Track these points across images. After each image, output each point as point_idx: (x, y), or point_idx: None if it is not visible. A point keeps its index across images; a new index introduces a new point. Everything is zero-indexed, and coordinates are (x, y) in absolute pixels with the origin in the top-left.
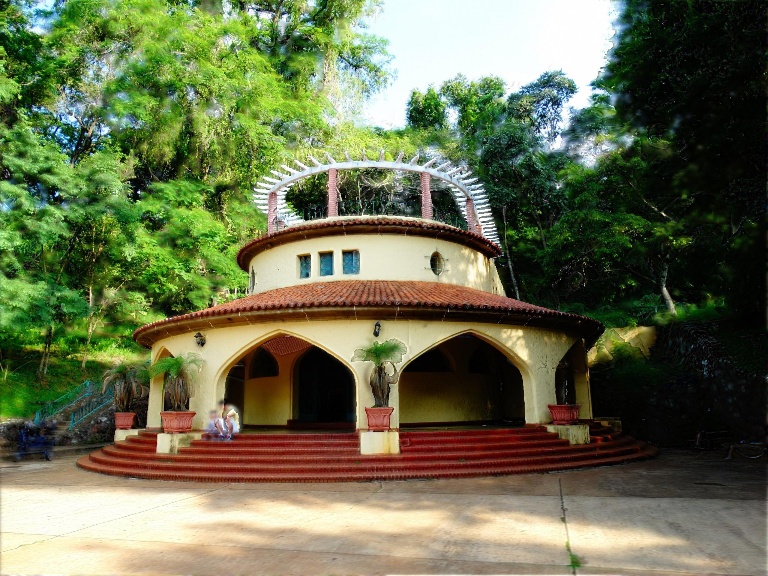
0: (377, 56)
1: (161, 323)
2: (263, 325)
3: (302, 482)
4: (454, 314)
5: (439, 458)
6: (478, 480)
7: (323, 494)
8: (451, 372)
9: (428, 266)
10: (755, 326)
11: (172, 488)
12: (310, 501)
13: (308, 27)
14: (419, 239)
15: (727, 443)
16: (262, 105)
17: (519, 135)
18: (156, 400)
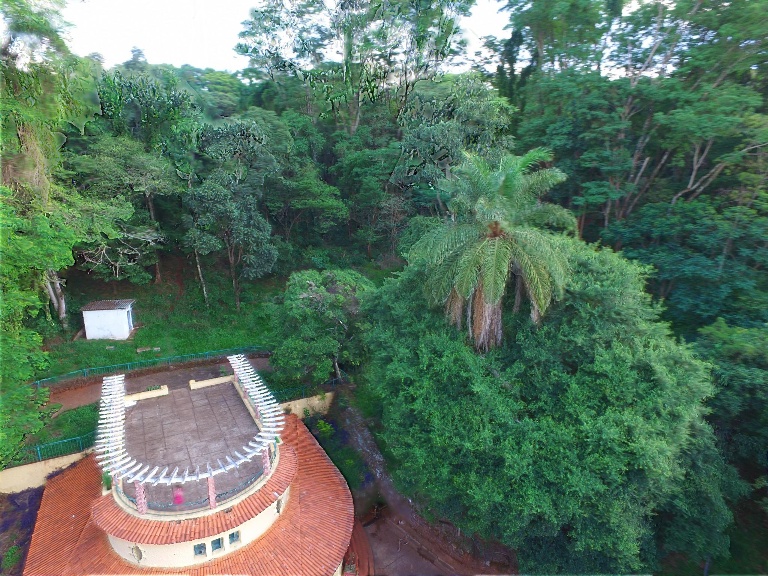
0: None
1: None
2: None
3: None
4: None
5: None
6: None
7: None
8: None
9: (275, 512)
10: None
11: None
12: None
13: (6, 105)
14: None
15: (389, 520)
16: (6, 273)
17: (224, 193)
18: None
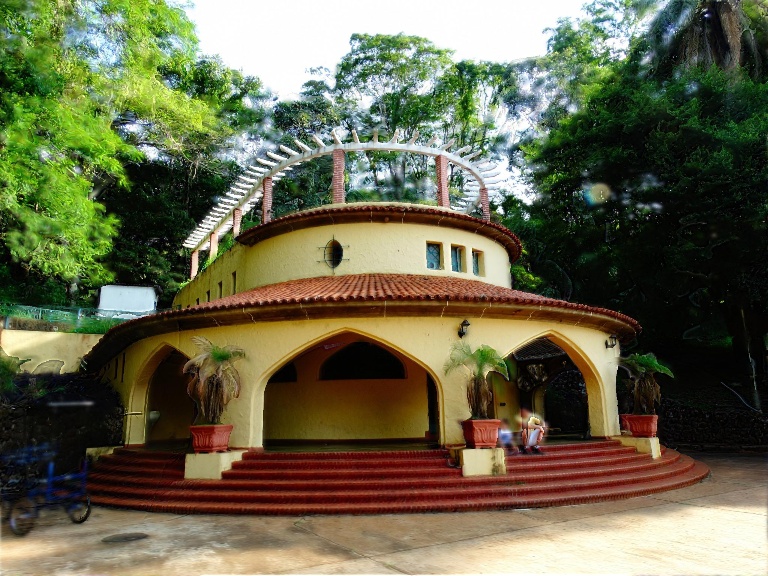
0: None
1: (413, 299)
2: (538, 323)
3: (681, 487)
4: None
5: None
6: None
7: None
8: None
9: (510, 281)
10: None
11: (645, 508)
12: None
13: None
14: None
15: None
16: None
17: None
18: (260, 405)
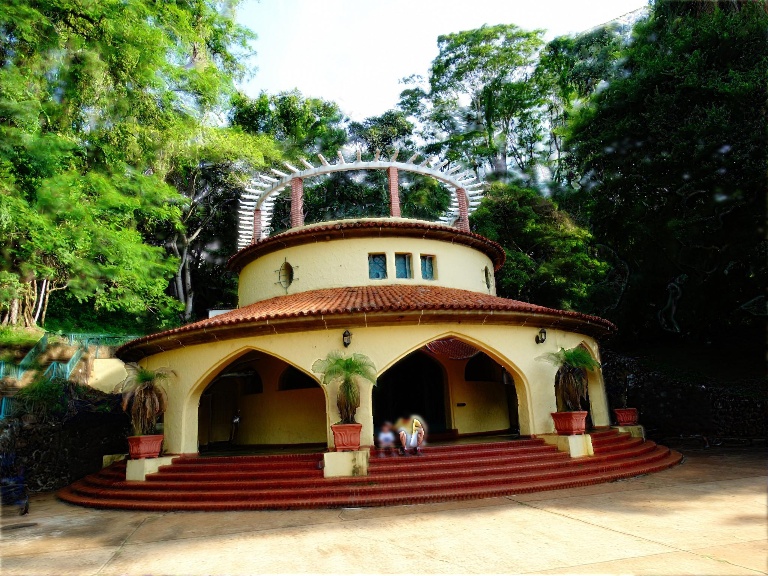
0: (237, 46)
1: (289, 316)
2: (433, 326)
3: (568, 487)
4: (584, 326)
5: (624, 456)
6: (676, 471)
7: (644, 492)
8: (499, 382)
9: (484, 279)
10: (628, 350)
11: (469, 508)
12: (672, 497)
13: None
14: (477, 252)
15: (670, 437)
16: (173, 67)
17: None
18: (192, 417)
